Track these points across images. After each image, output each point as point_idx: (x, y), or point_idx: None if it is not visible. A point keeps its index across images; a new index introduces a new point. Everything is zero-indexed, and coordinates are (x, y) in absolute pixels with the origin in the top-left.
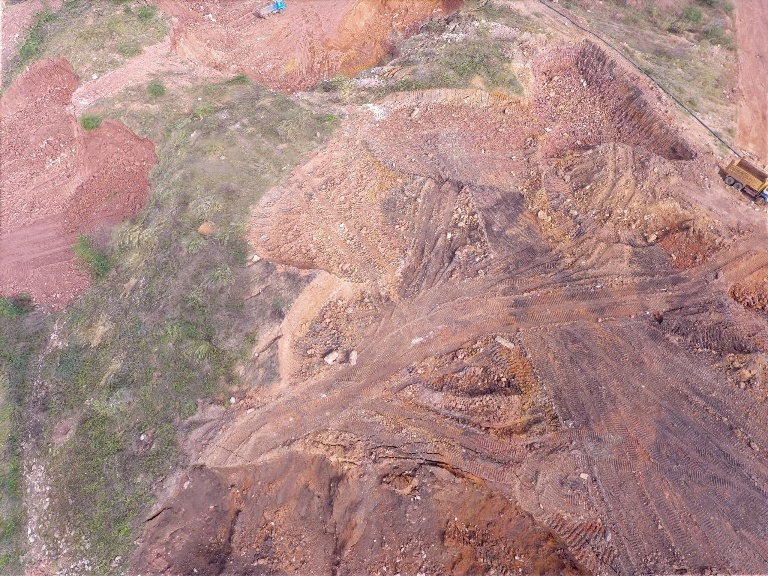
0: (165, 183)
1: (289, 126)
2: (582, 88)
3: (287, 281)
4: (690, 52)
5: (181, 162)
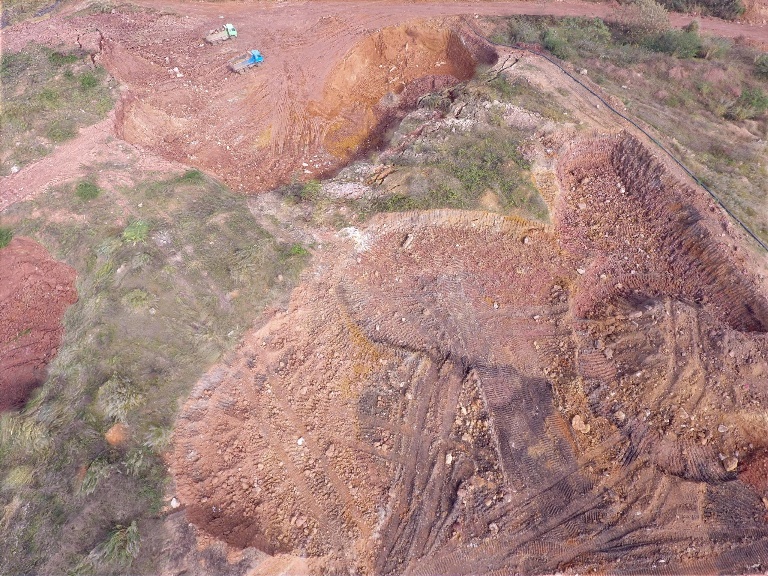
0: (74, 348)
1: (244, 260)
2: (620, 197)
3: (209, 568)
4: (755, 150)
5: (99, 314)
